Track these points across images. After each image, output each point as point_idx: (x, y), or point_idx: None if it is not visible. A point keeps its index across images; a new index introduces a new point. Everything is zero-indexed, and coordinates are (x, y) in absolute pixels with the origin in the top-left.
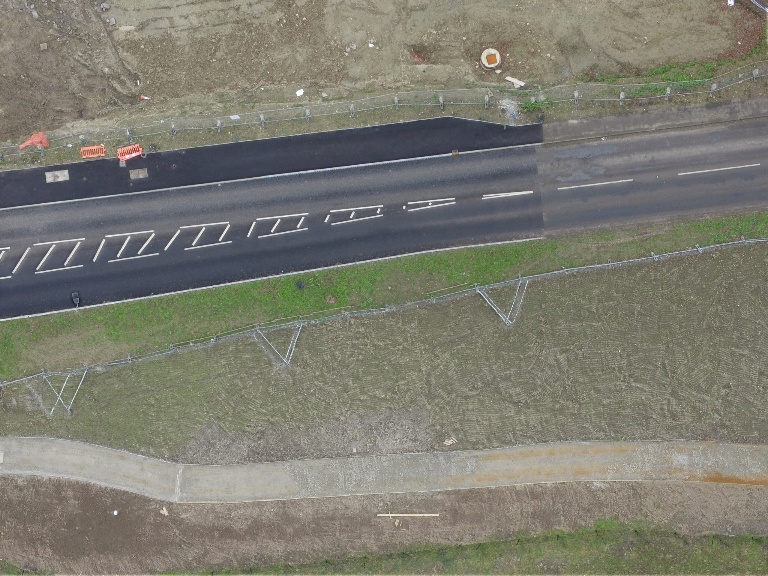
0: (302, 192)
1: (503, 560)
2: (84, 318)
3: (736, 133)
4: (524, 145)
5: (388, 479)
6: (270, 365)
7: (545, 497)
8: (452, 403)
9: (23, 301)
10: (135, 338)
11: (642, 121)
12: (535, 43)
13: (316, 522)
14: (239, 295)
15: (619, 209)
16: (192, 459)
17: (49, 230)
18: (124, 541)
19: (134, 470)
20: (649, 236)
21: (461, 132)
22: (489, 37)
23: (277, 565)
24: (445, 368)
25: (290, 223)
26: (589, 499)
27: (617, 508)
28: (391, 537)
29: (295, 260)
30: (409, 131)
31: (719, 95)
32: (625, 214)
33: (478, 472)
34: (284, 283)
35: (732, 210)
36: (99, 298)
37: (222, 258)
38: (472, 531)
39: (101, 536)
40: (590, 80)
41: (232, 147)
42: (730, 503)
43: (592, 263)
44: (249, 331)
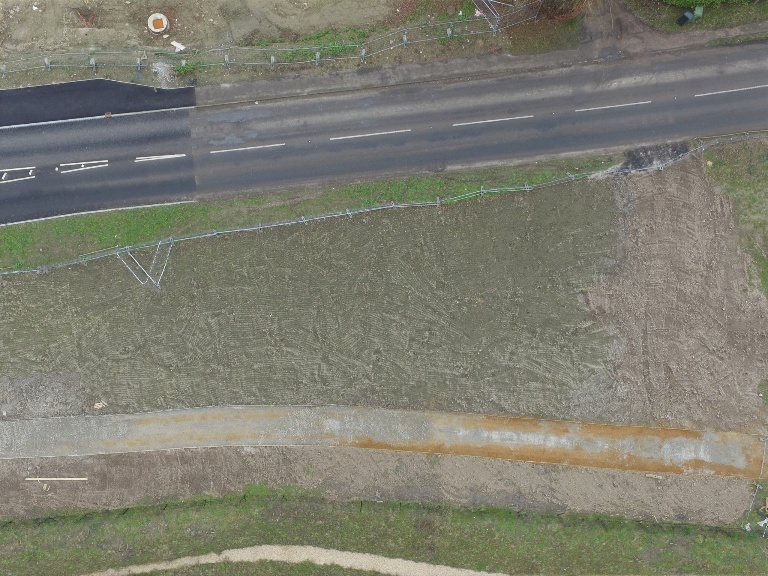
0: None
1: (150, 525)
2: None
3: (388, 99)
4: (177, 108)
5: (39, 443)
6: None
7: (195, 462)
8: (103, 366)
9: None
10: None
11: (294, 86)
12: (198, 8)
13: None
14: None
15: (271, 173)
16: None
17: None
18: None
19: None
20: (300, 200)
21: (113, 94)
22: (156, 2)
23: None
24: (96, 331)
25: None
26: (239, 464)
27: (266, 473)
28: (39, 501)
29: None
30: (61, 93)
31: (370, 61)
32: (277, 178)
33: (130, 436)
34: None
35: (382, 175)
36: None
37: None
38: (120, 496)
39: None
40: (247, 45)
41: None
42: (380, 469)
43: (243, 227)
44: None
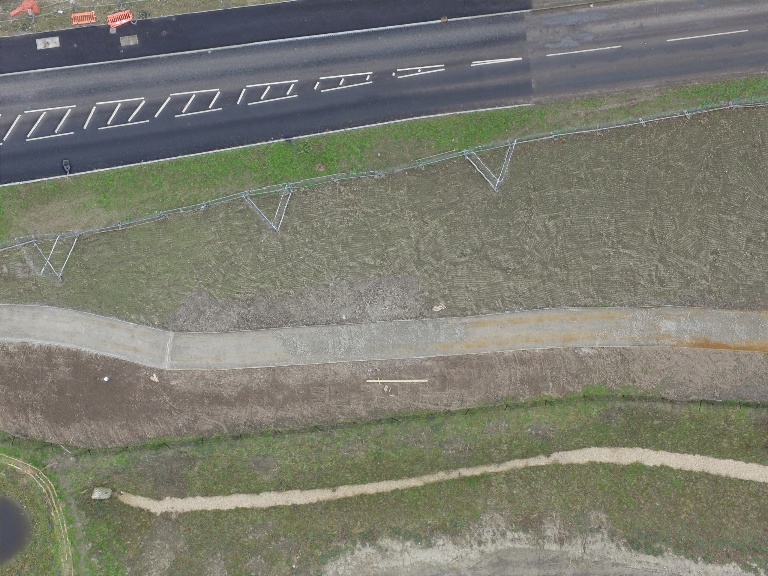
0: (292, 59)
1: (491, 425)
2: (75, 185)
3: None
4: (513, 12)
5: (377, 346)
6: (260, 232)
7: (533, 363)
8: (441, 270)
9: (14, 168)
10: (125, 205)
11: None
12: None
13: (305, 388)
14: (229, 162)
15: (607, 75)
16: (182, 326)
17: (40, 97)
18: (114, 408)
19: (124, 338)
20: (637, 102)
21: None
22: None
23: (267, 431)
24: (434, 235)
25: (280, 90)
26: (577, 365)
27: (605, 374)
28: (380, 403)
29: (285, 127)
30: None
31: None
32: (613, 80)
33: (467, 339)
34: (274, 149)
35: (720, 76)
36: (90, 165)
37: (212, 125)
38: (461, 397)
39: (92, 403)
40: None
41: (222, 14)
42: (718, 369)
43: (580, 129)
44: (239, 198)
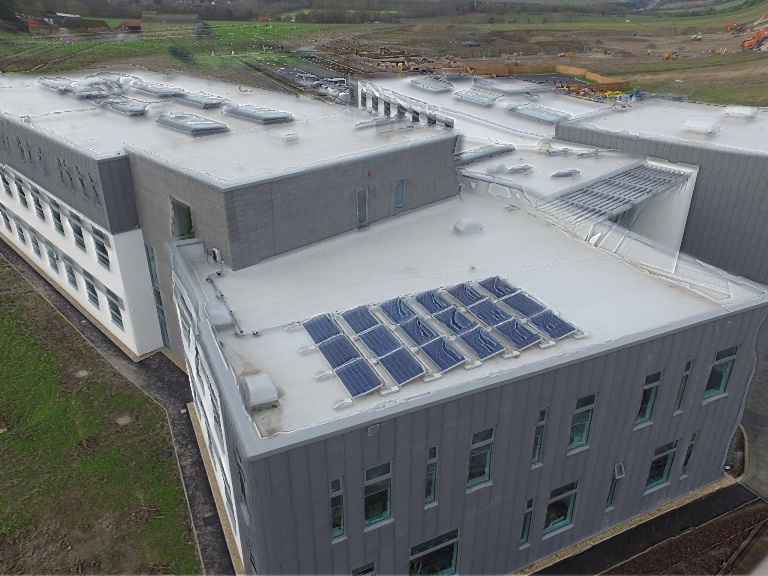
0: None
1: None
2: None
3: None
4: None
5: None
6: None
7: None
8: None
9: None
10: None
11: None
12: None
13: None
14: None
15: None
16: None
17: None
18: None
19: None
20: None
21: None
22: None
23: None
24: None
25: None
26: None
27: None
28: None
29: None
30: None
31: None
32: None
33: None
34: None
35: None
36: None
37: None
38: None
39: None
40: None
41: None
42: None
43: None
44: None
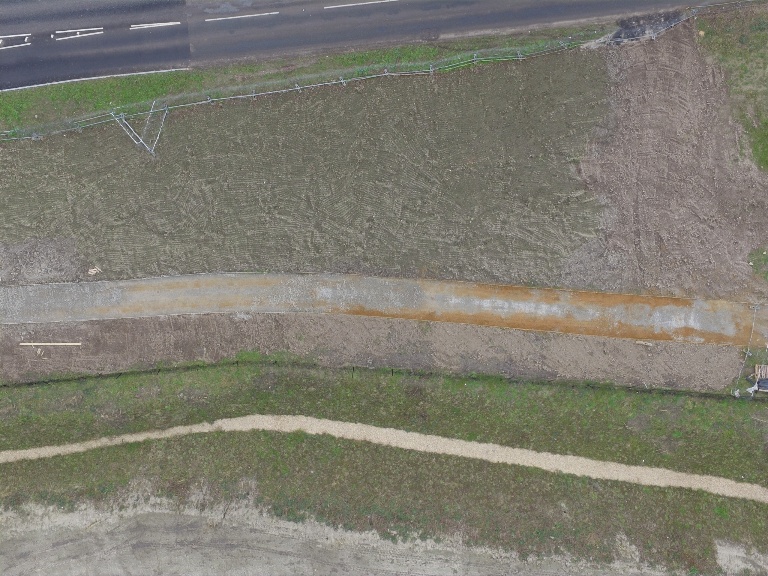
0: None
1: (144, 390)
2: None
3: None
4: None
5: (33, 309)
6: None
7: (188, 328)
8: (97, 233)
9: None
10: None
11: None
12: None
13: None
14: None
15: (265, 41)
16: None
17: None
18: None
19: None
20: (294, 68)
21: None
22: None
23: None
24: (91, 198)
25: None
26: (232, 330)
27: (259, 339)
28: (33, 366)
29: None
30: None
31: None
32: (271, 46)
33: (123, 303)
34: None
35: (376, 44)
36: None
37: None
38: (114, 361)
39: None
40: None
41: None
42: (372, 336)
43: (237, 94)
44: None
